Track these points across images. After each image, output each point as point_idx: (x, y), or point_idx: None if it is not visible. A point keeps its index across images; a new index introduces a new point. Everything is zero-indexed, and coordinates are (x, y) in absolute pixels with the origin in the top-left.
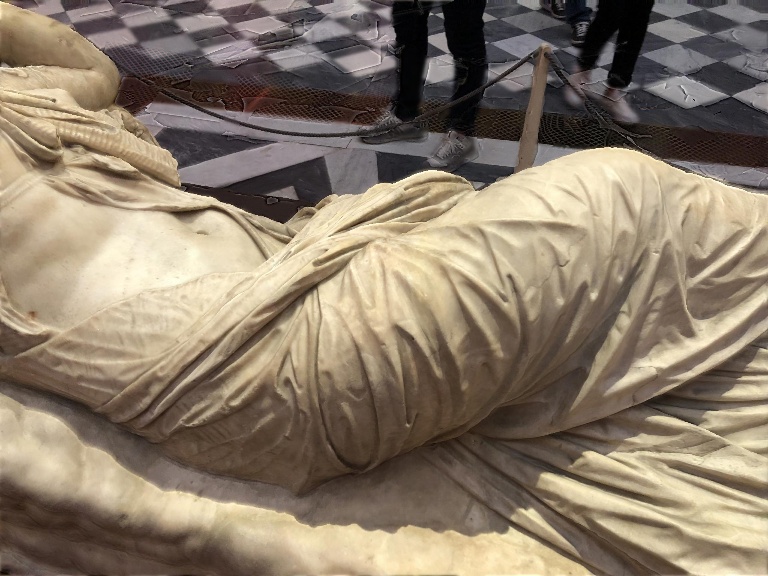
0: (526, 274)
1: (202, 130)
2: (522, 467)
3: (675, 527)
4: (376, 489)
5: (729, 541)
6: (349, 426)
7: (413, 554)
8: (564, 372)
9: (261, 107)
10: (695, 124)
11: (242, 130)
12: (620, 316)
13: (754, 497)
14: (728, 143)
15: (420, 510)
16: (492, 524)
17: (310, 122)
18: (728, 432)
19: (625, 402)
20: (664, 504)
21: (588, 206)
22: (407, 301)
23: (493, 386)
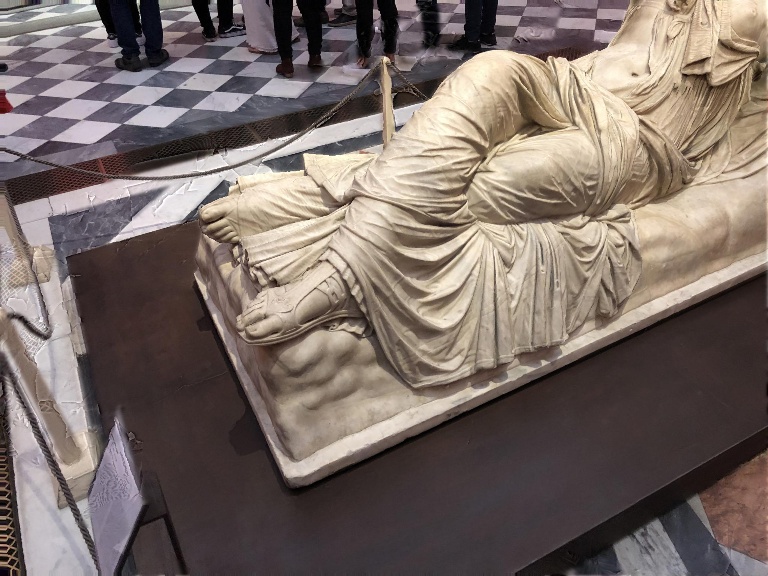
0: None
1: None
2: None
3: None
4: None
5: None
6: None
7: None
8: None
9: None
10: None
11: None
12: None
13: None
14: None
15: None
16: None
17: None
18: None
19: None
20: None
21: None
22: None
23: None
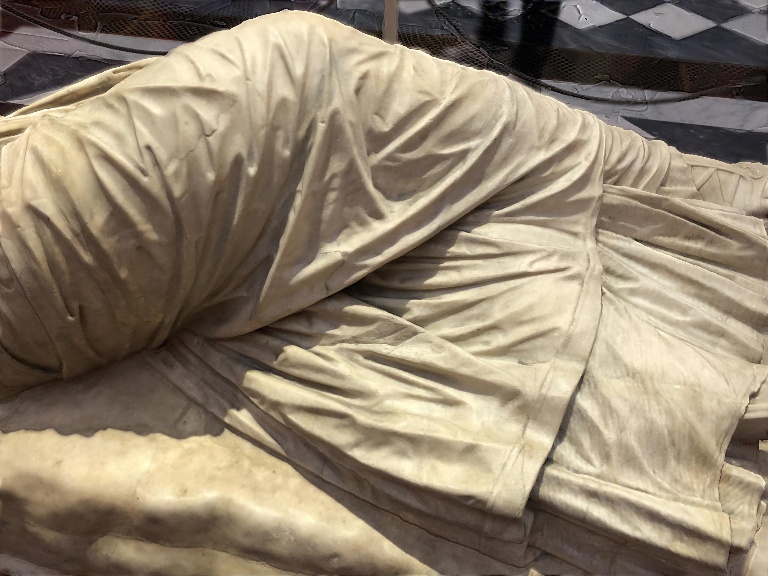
0: (168, 145)
1: (51, 49)
2: (233, 366)
3: (350, 416)
4: (85, 394)
5: (396, 428)
6: (9, 320)
7: (107, 457)
8: (256, 261)
9: (109, 23)
10: (586, 45)
11: (93, 49)
12: (297, 196)
13: (437, 384)
14: (615, 63)
15: (126, 413)
16: (207, 426)
17: (164, 39)
18: (431, 321)
19: (318, 291)
20: (353, 395)
21: (242, 70)
22: (42, 178)
23: (163, 274)
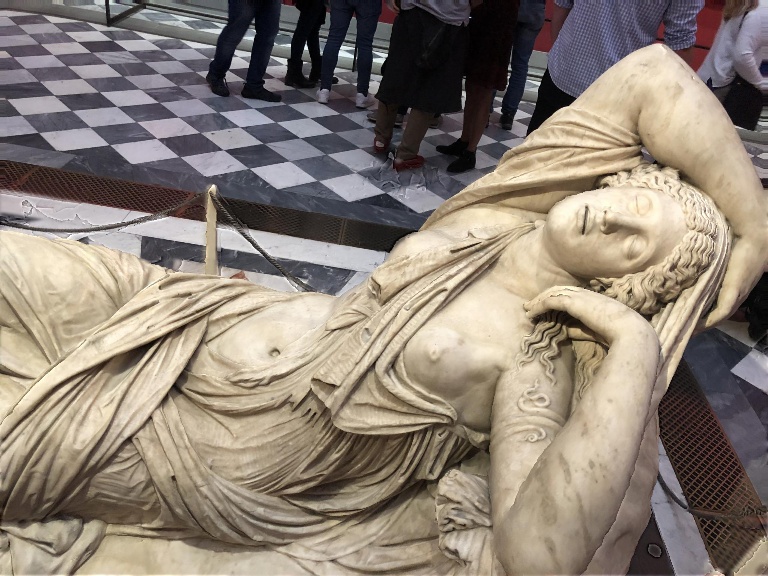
0: None
1: None
2: None
3: None
4: None
5: None
6: None
7: None
8: None
9: None
10: None
11: None
12: None
13: None
14: None
15: None
16: None
17: None
18: None
19: None
20: None
21: None
22: None
23: None
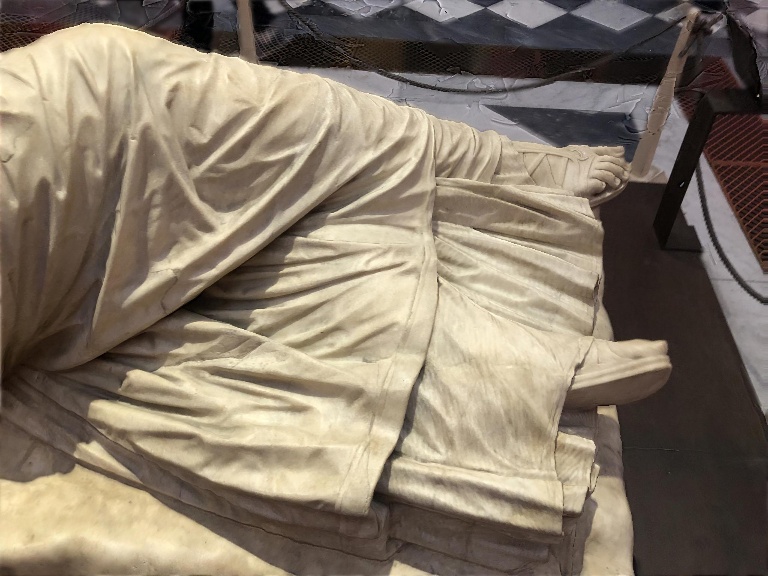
0: None
1: None
2: (76, 398)
3: (197, 436)
4: None
5: (243, 442)
6: None
7: None
8: (85, 287)
9: None
10: (448, 37)
11: None
12: (117, 216)
13: (284, 392)
14: (476, 54)
15: None
16: (56, 464)
17: None
18: (276, 329)
19: (155, 311)
20: (201, 414)
21: (37, 90)
22: None
23: None
